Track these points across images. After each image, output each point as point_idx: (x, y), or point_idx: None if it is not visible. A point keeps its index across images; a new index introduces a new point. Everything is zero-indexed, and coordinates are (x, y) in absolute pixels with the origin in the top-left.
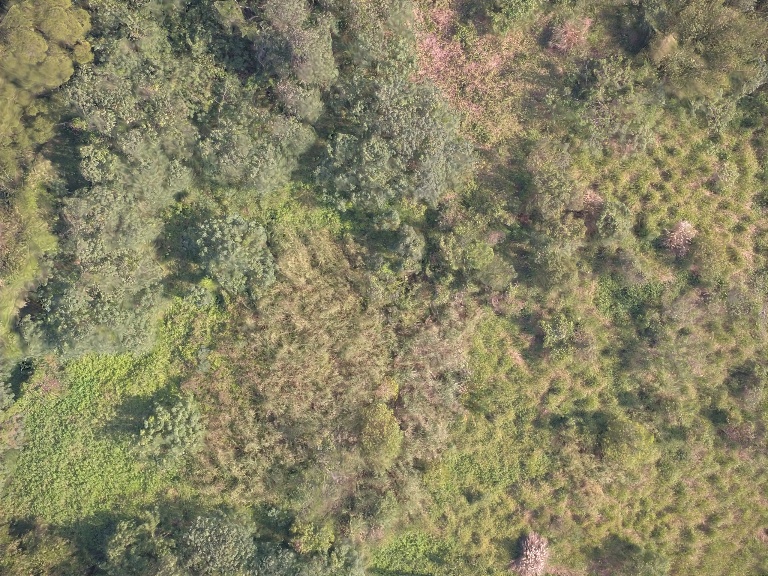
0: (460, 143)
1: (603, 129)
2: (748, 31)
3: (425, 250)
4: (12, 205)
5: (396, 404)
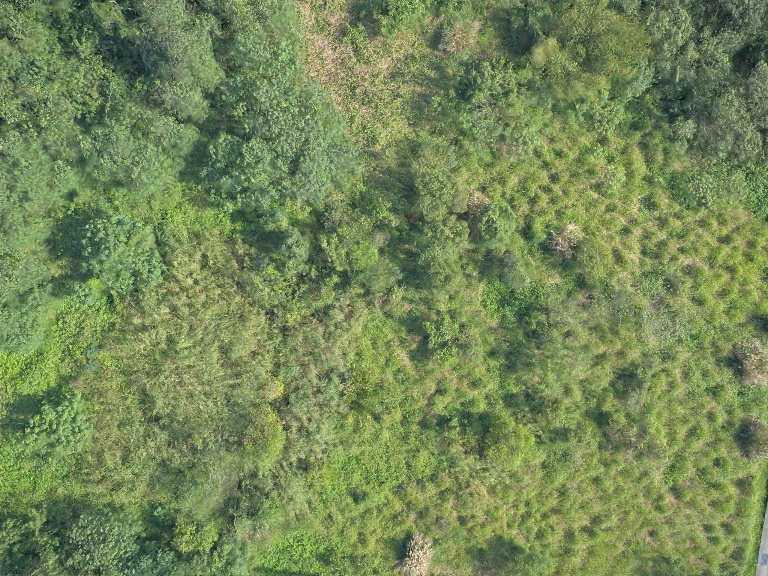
0: None
1: (486, 131)
2: (627, 35)
3: (314, 251)
4: None
5: (281, 404)
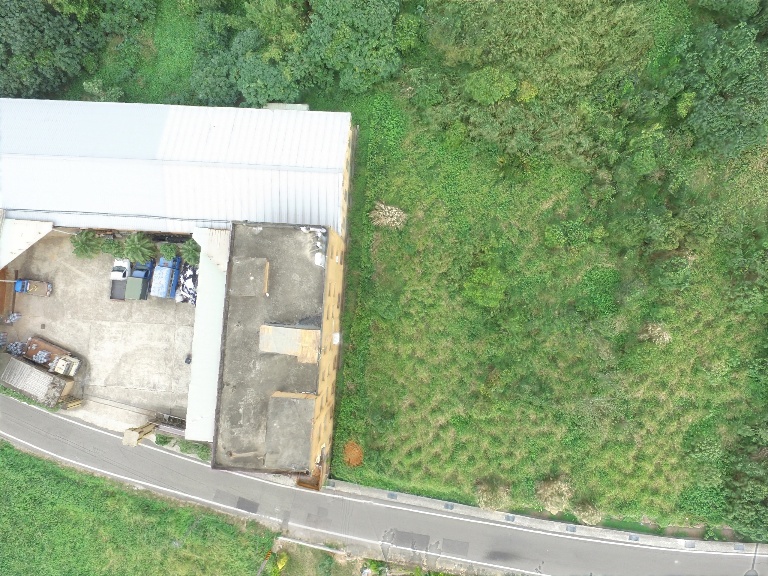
0: None
1: (761, 262)
2: None
3: None
4: None
5: (512, 101)
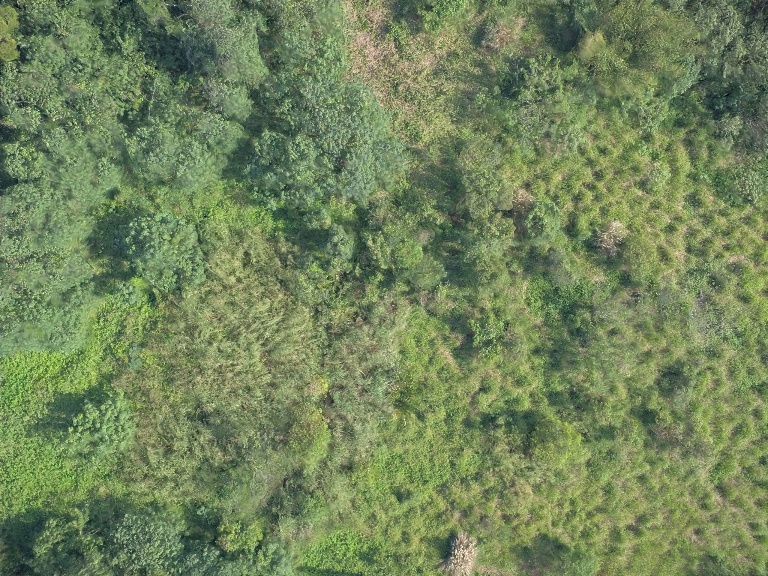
0: (391, 142)
1: (532, 128)
2: (675, 31)
3: (357, 249)
4: None
5: (325, 403)
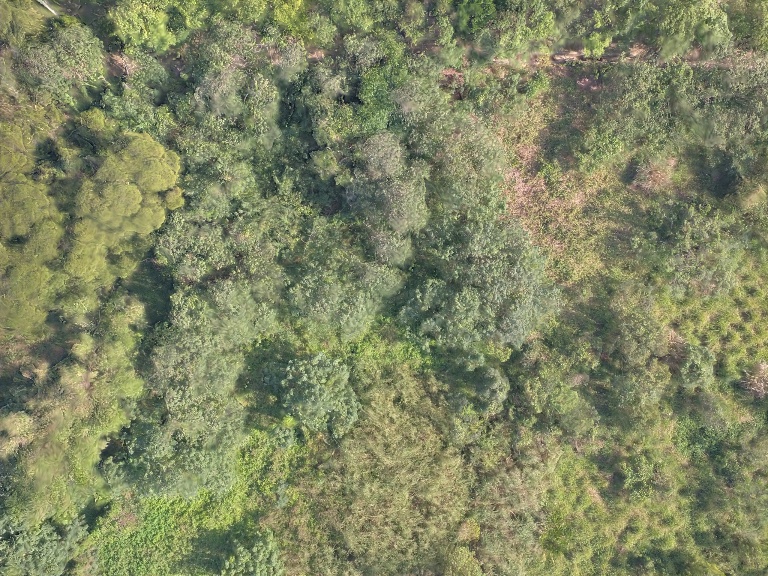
0: (544, 282)
1: (689, 276)
2: None
3: None
4: (101, 354)
5: (477, 544)
